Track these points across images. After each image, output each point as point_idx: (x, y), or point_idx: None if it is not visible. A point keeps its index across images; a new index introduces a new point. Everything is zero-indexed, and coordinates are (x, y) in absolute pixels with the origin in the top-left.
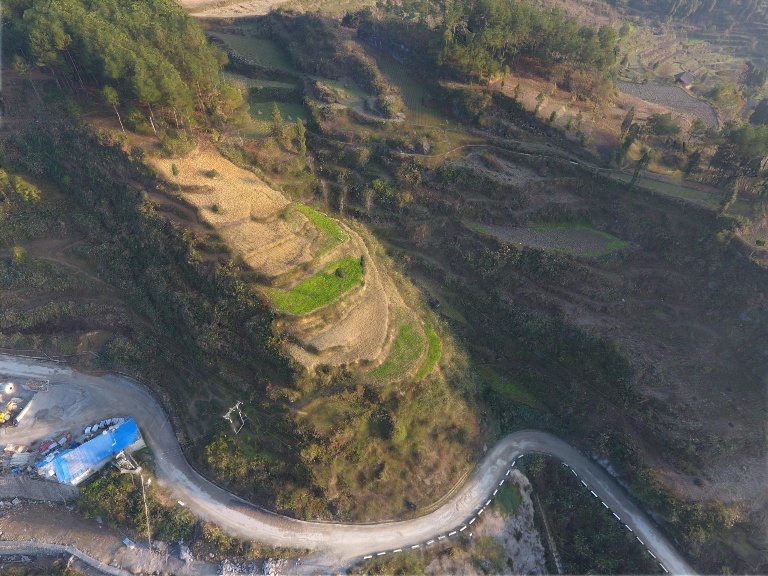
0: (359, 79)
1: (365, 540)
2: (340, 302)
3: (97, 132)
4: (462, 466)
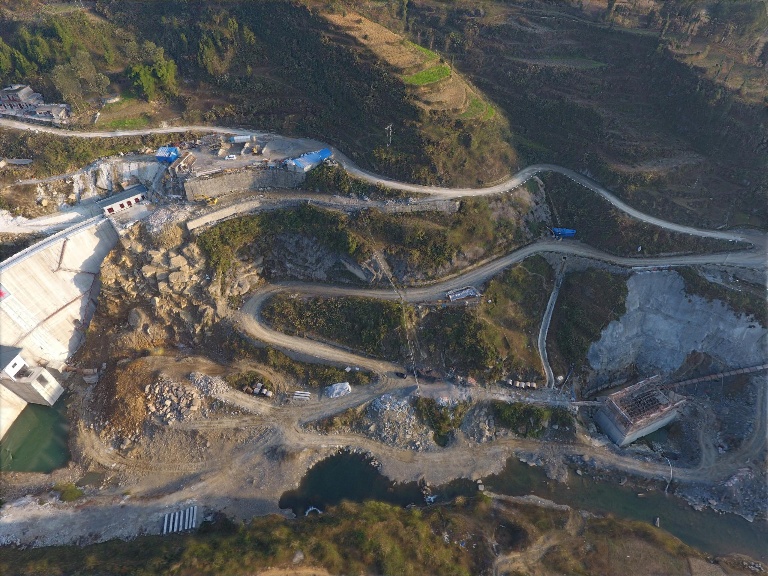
0: None
1: (457, 193)
2: (440, 83)
3: None
4: (506, 171)
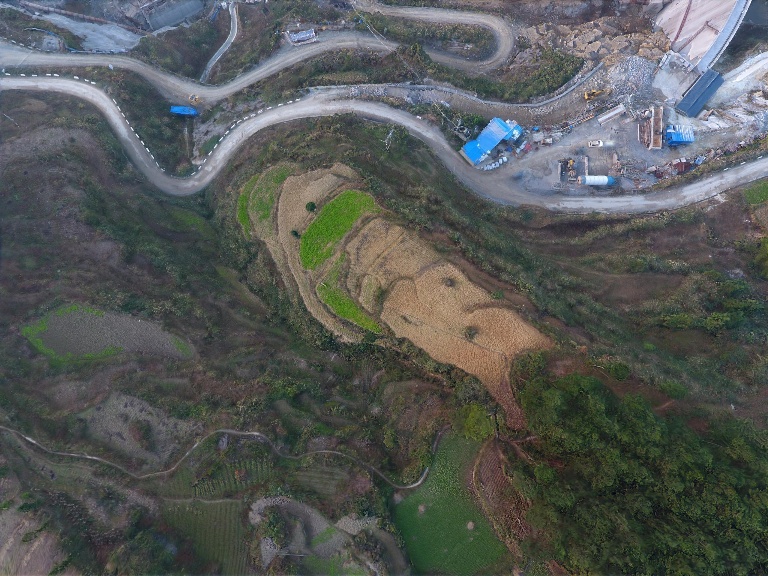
0: None
1: (301, 109)
2: None
3: (629, 366)
4: None
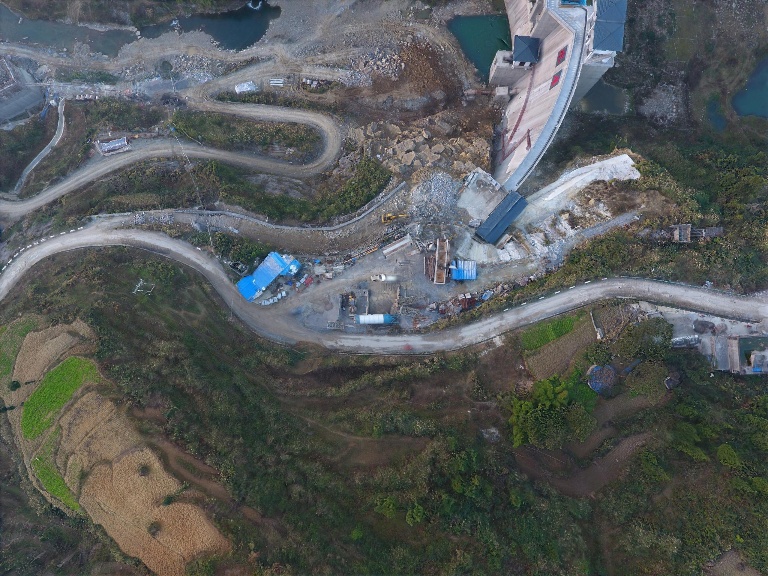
0: None
1: (83, 238)
2: None
3: None
4: None
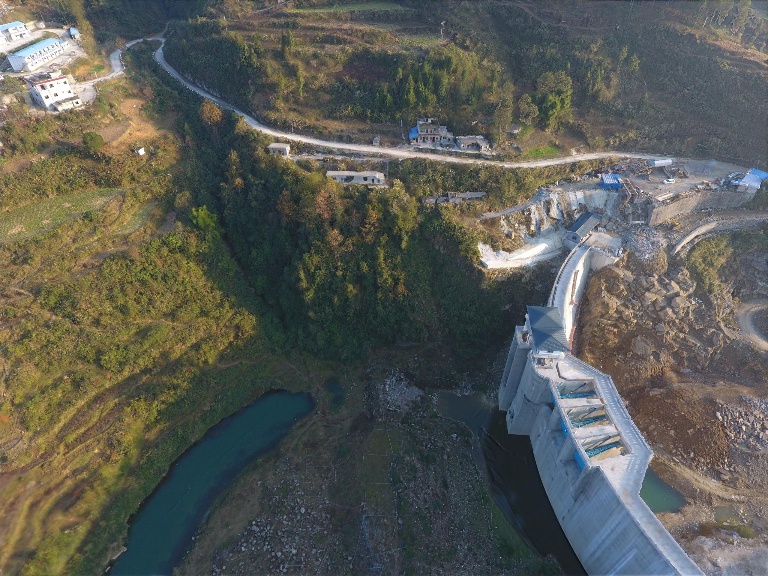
0: (759, 2)
1: None
2: None
3: (677, 27)
4: None
